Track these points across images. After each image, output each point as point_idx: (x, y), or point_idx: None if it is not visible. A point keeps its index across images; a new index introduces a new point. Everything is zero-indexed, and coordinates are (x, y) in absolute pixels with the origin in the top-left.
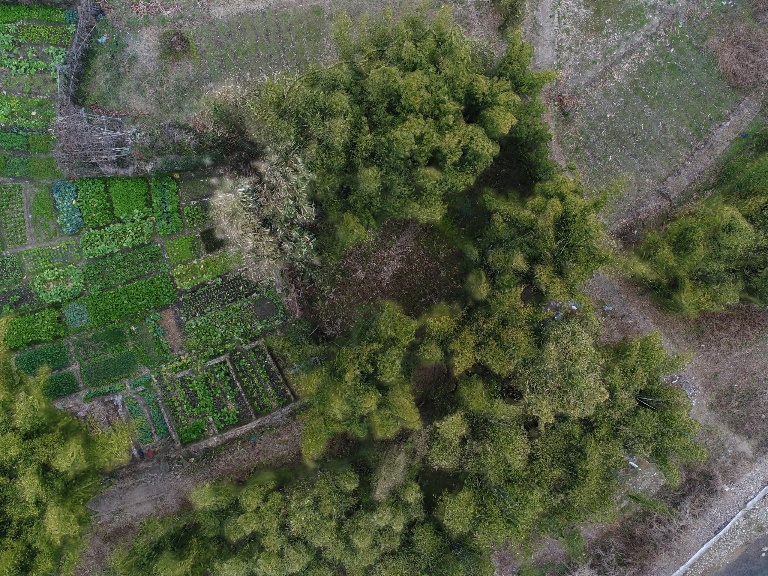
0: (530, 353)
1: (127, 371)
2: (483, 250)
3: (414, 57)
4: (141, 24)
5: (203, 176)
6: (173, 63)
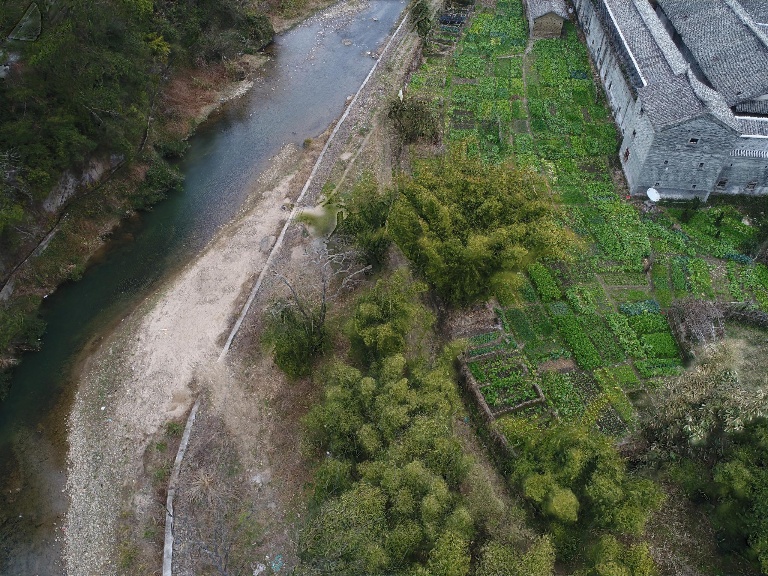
0: None
1: (520, 334)
2: None
3: None
4: None
5: None
6: None
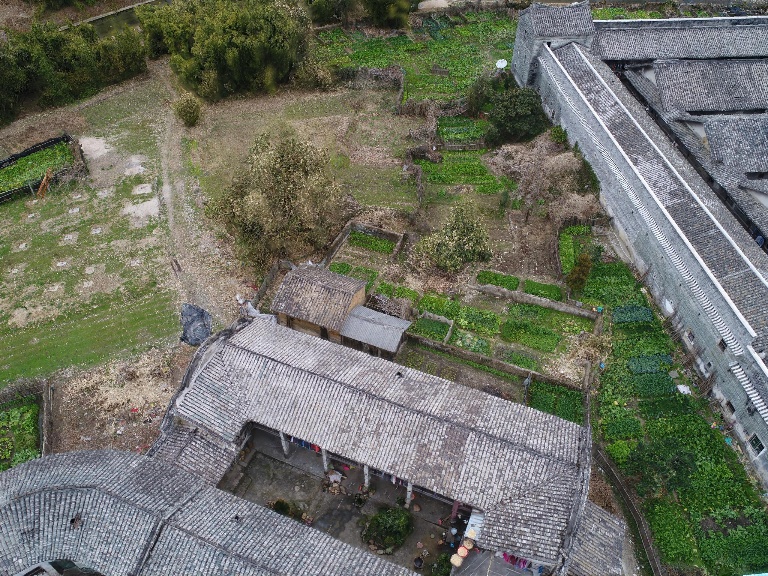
0: None
1: None
2: None
3: None
4: None
5: None
6: None
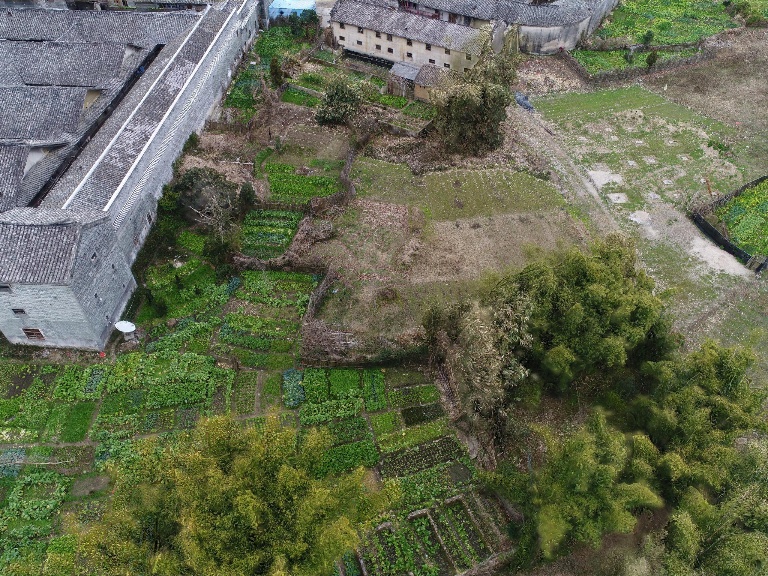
0: (737, 458)
1: None
2: (659, 401)
3: (587, 261)
4: (363, 284)
5: (404, 372)
6: (384, 305)
